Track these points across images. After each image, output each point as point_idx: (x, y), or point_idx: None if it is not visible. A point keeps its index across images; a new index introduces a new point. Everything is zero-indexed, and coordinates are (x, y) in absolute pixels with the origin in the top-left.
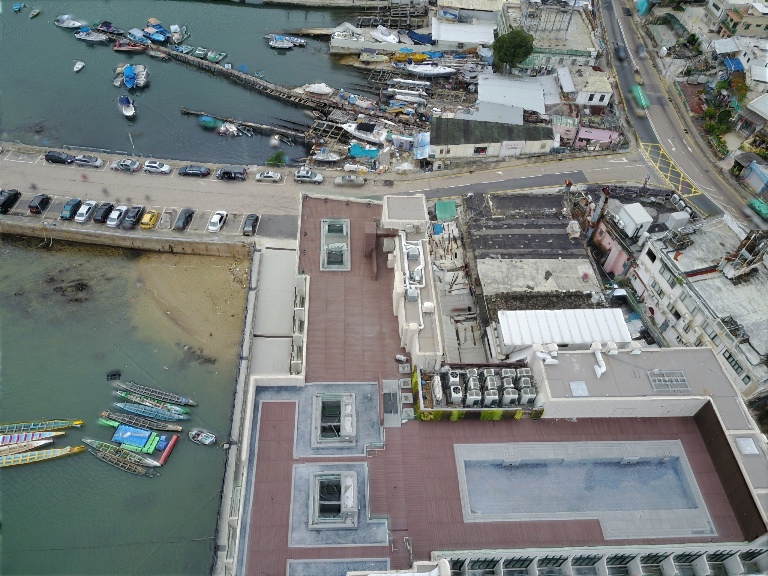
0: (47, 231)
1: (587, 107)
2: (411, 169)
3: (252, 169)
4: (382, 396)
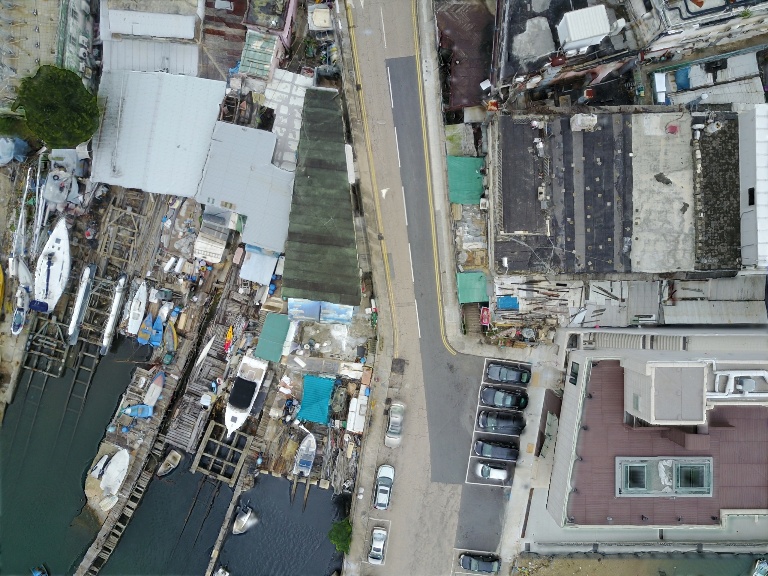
0: None
1: (211, 1)
2: (347, 326)
3: (353, 571)
4: None
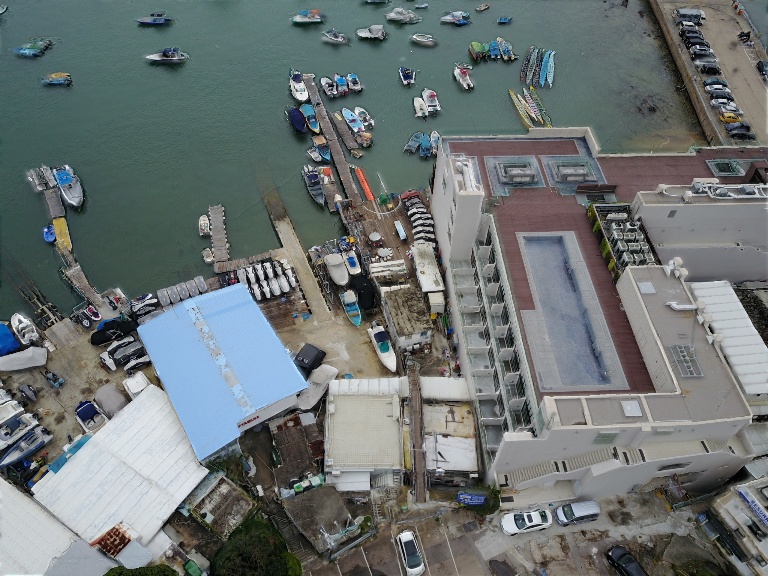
0: (690, 81)
1: None
2: None
3: None
4: (597, 184)
